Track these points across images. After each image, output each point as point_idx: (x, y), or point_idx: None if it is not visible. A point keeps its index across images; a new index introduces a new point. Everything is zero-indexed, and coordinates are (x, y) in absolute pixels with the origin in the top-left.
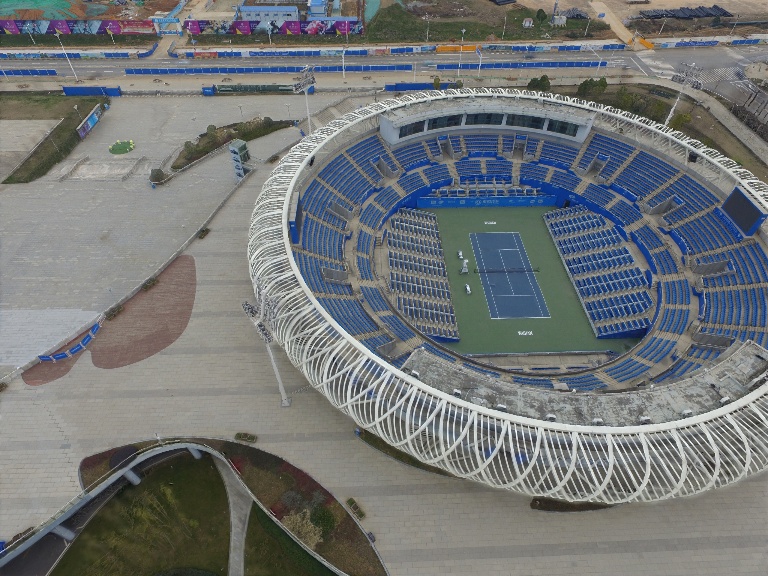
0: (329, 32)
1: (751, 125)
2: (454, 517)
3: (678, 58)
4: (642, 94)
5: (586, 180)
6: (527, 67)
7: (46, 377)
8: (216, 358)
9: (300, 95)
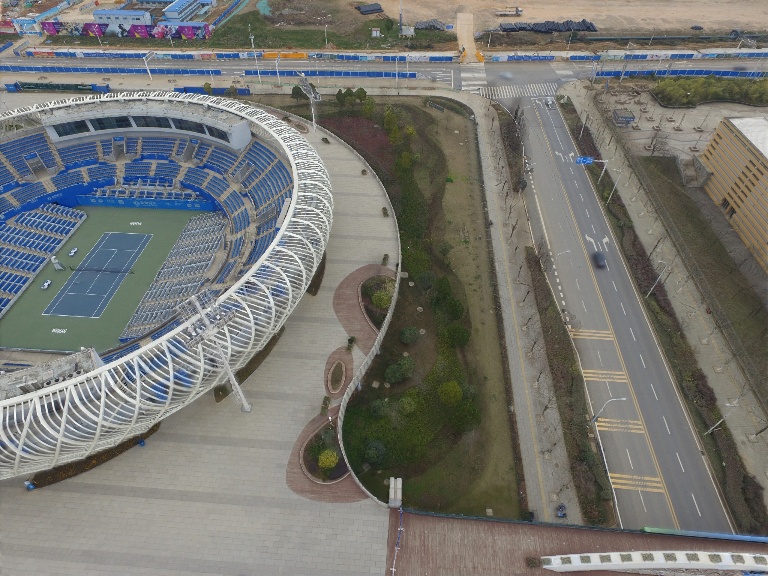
0: (175, 36)
1: (504, 142)
2: None
3: (501, 72)
4: (416, 106)
5: (234, 187)
6: (336, 76)
7: None
8: None
9: None
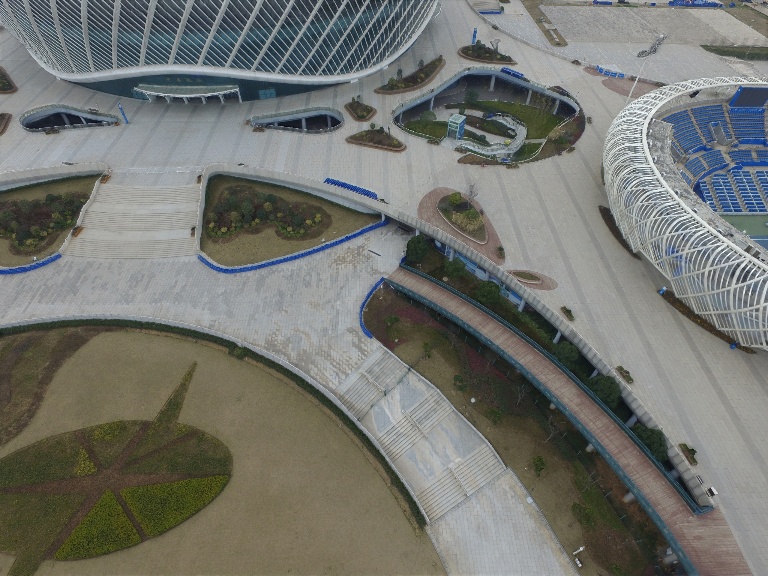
0: None
1: None
2: (581, 179)
3: None
4: None
5: None
6: None
7: (589, 72)
8: None
9: None
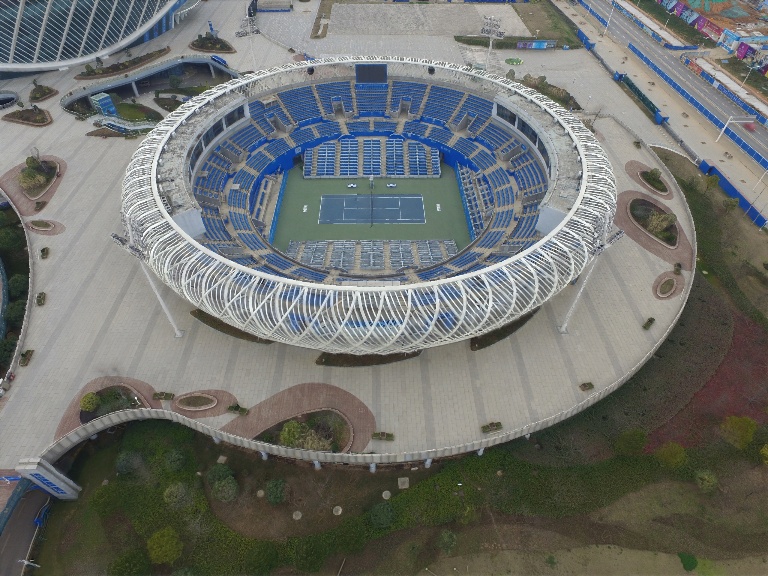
0: None
1: None
2: None
3: None
4: None
5: (491, 251)
6: None
7: (296, 58)
8: None
9: (648, 118)
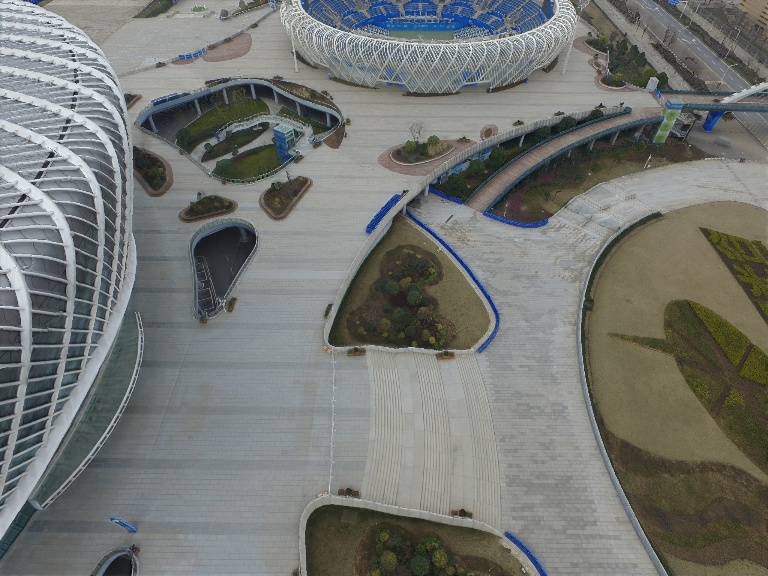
0: None
1: (613, 2)
2: (368, 96)
3: None
4: None
5: (479, 12)
6: None
7: (183, 63)
8: (263, 60)
9: None
